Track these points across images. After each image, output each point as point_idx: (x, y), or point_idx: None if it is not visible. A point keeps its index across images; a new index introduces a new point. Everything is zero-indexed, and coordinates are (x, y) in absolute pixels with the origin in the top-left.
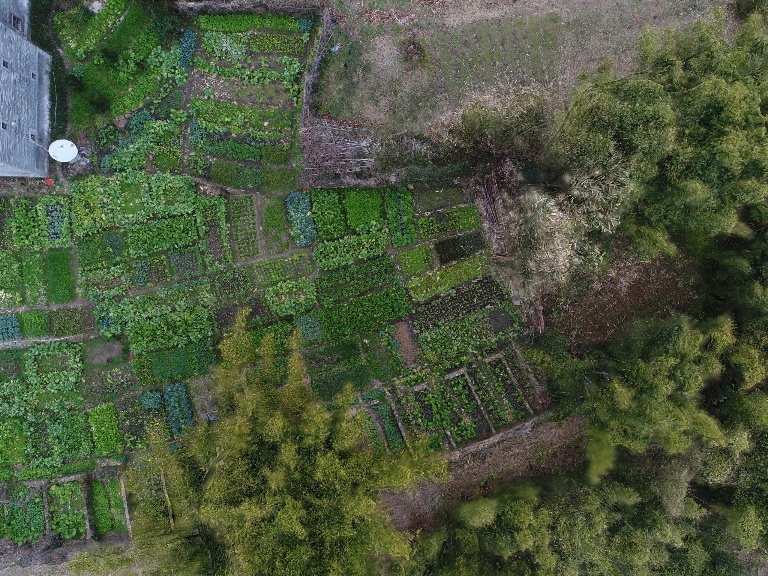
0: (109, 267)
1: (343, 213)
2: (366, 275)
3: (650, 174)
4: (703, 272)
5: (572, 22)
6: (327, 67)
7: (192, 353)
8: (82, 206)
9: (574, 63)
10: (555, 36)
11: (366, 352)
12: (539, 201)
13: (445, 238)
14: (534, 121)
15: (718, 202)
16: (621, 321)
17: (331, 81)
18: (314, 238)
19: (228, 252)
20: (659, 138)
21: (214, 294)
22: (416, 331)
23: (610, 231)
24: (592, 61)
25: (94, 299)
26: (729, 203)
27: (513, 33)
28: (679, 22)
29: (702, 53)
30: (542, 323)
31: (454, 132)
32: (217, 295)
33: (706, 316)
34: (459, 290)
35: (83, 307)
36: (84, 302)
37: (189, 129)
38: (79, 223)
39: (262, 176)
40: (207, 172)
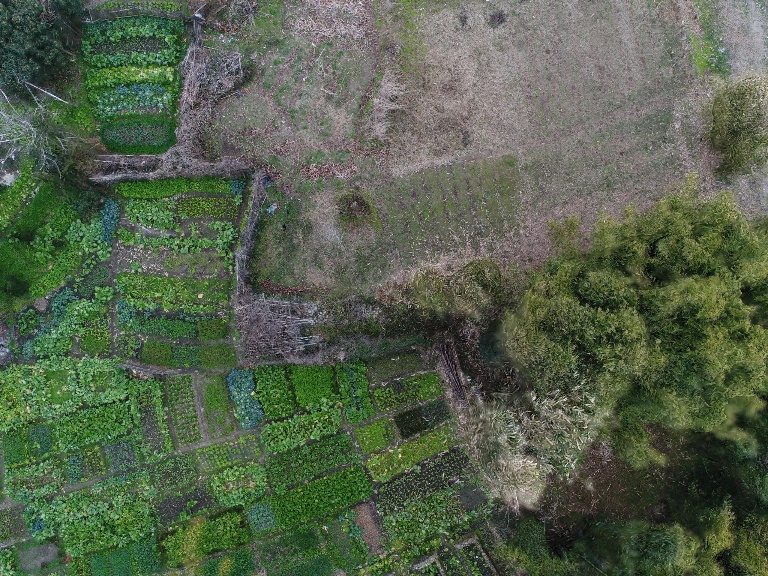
0: (38, 462)
1: (291, 389)
2: (320, 456)
3: (620, 386)
4: (693, 433)
5: (530, 164)
6: (264, 229)
7: (134, 554)
8: (4, 400)
9: (535, 209)
10: (512, 181)
11: (326, 539)
12: (496, 418)
13: (405, 409)
14: (491, 296)
15: (701, 406)
16: (606, 491)
17: (269, 245)
18: (261, 418)
19: (167, 440)
20: (626, 356)
21: (155, 485)
22: (380, 513)
23: (579, 448)
24: (555, 206)
25: (23, 501)
26: (714, 401)
27: (466, 180)
28: (648, 157)
29: (671, 237)
30: (517, 505)
31: (408, 293)
32: (158, 486)
33: (700, 488)
34: (424, 465)
35: (12, 508)
36: (13, 502)
37: (117, 306)
38: (2, 418)
39: (199, 354)
40: (139, 353)
